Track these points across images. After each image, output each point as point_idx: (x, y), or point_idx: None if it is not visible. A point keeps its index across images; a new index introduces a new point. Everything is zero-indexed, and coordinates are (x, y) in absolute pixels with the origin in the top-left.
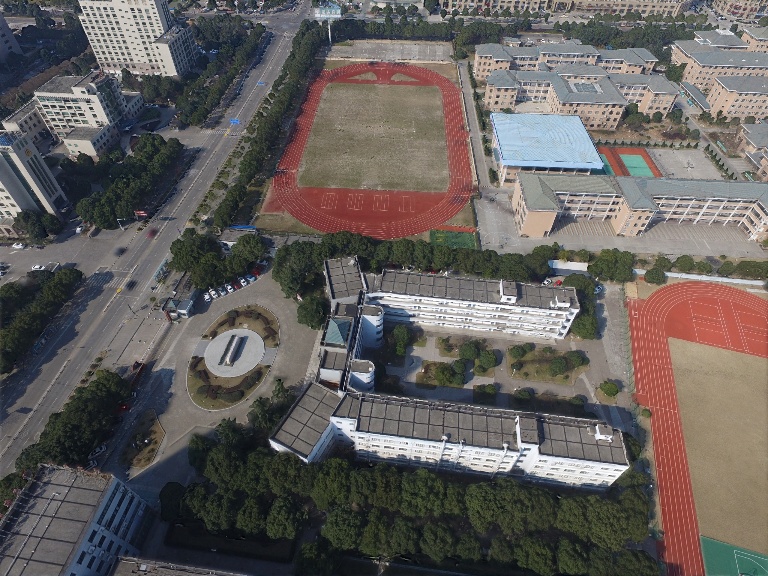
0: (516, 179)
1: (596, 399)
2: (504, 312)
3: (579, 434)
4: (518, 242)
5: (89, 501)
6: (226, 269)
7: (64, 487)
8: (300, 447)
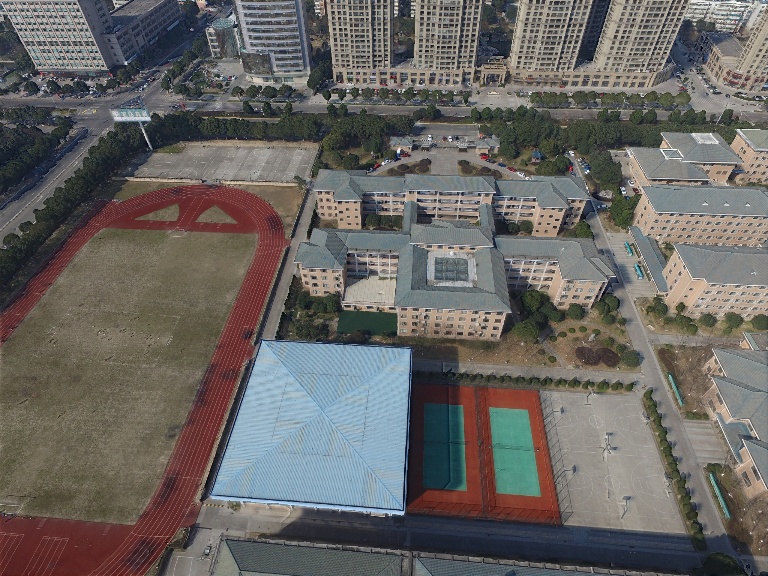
0: None
1: None
2: None
3: None
4: None
5: None
6: None
7: None
8: None
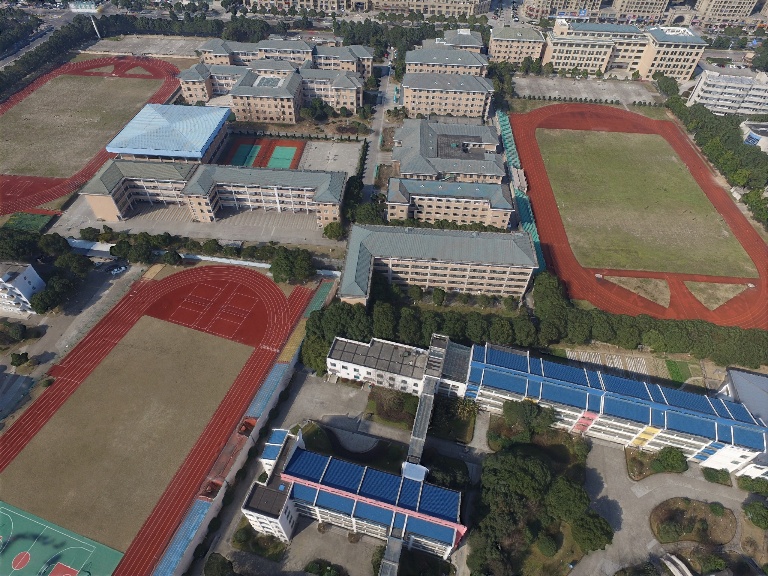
0: None
1: (14, 369)
2: None
3: None
4: (90, 225)
5: None
6: None
7: None
8: None
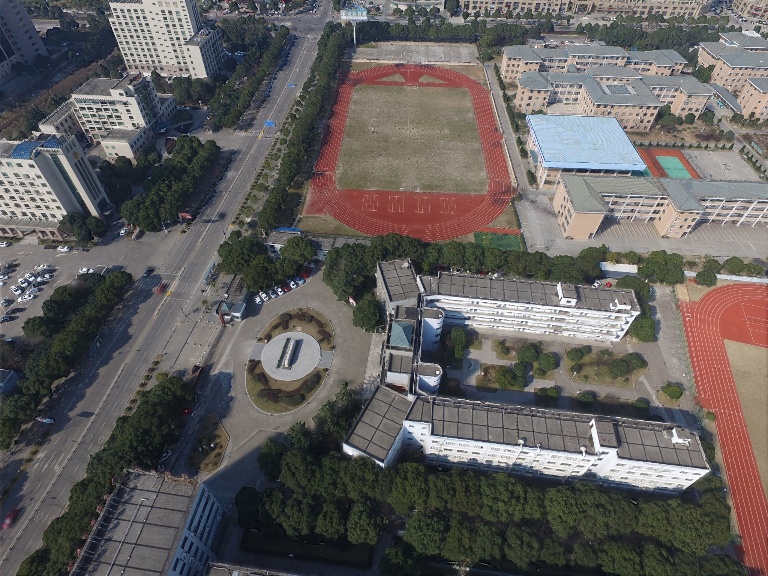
0: (556, 181)
1: (658, 402)
2: (563, 314)
3: (655, 437)
4: (563, 244)
5: (178, 507)
6: (277, 272)
7: (151, 493)
8: (375, 451)
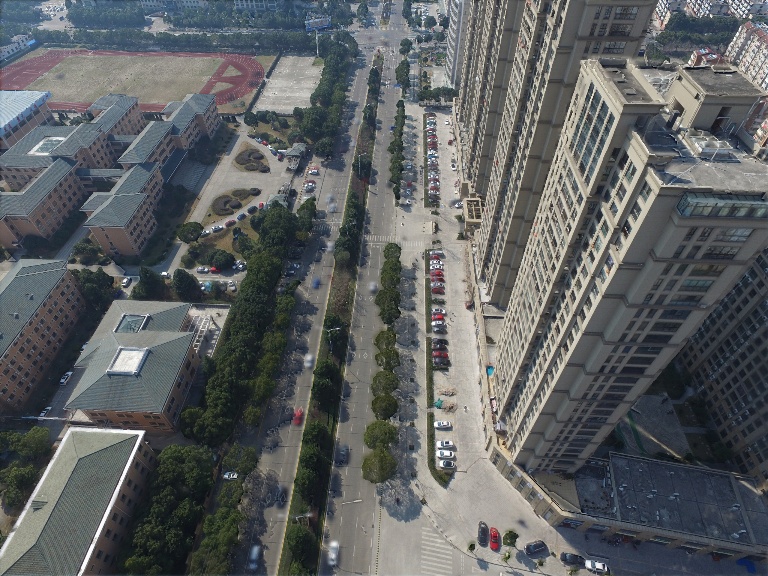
0: None
1: None
2: None
3: None
4: None
5: None
6: None
7: None
8: None
